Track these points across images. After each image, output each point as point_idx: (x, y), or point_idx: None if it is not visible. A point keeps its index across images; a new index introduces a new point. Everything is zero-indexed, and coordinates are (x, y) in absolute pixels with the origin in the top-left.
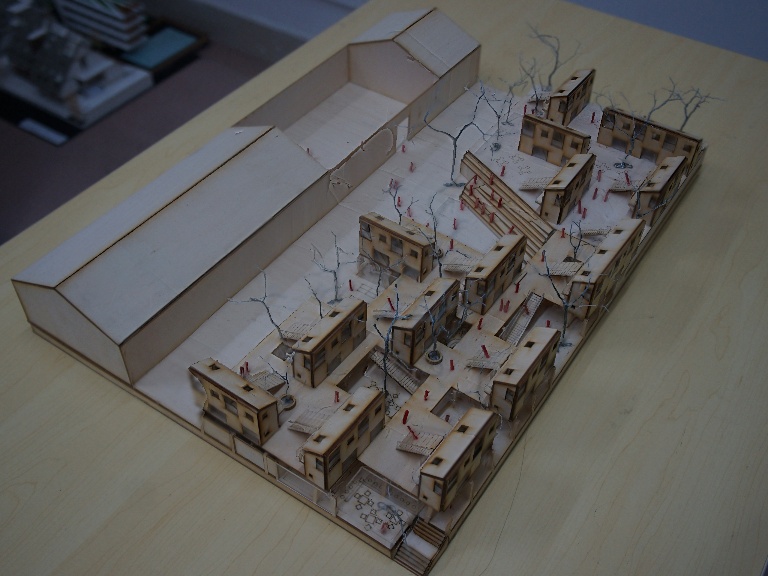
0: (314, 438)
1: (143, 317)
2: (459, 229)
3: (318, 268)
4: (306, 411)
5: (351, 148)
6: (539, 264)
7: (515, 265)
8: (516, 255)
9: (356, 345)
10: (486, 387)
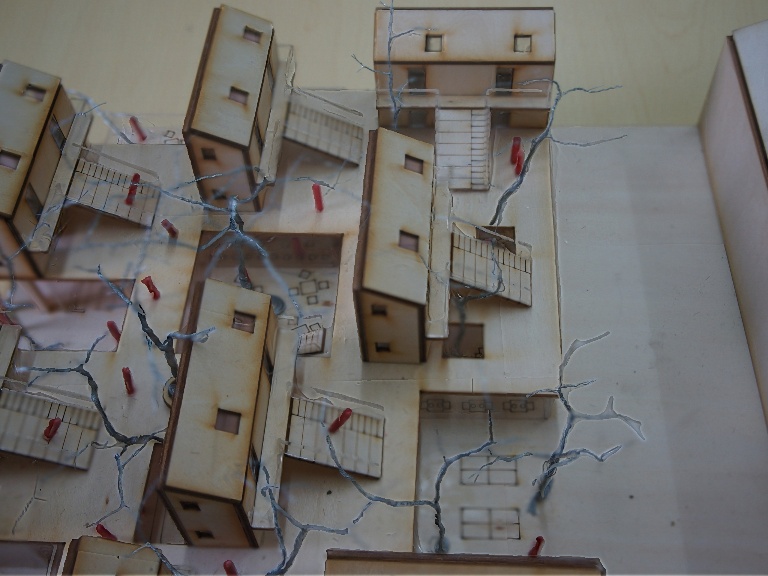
0: (264, 36)
1: (760, 81)
2: None
3: (671, 573)
4: (355, 158)
5: None
6: None
7: None
8: None
9: None
10: (16, 329)
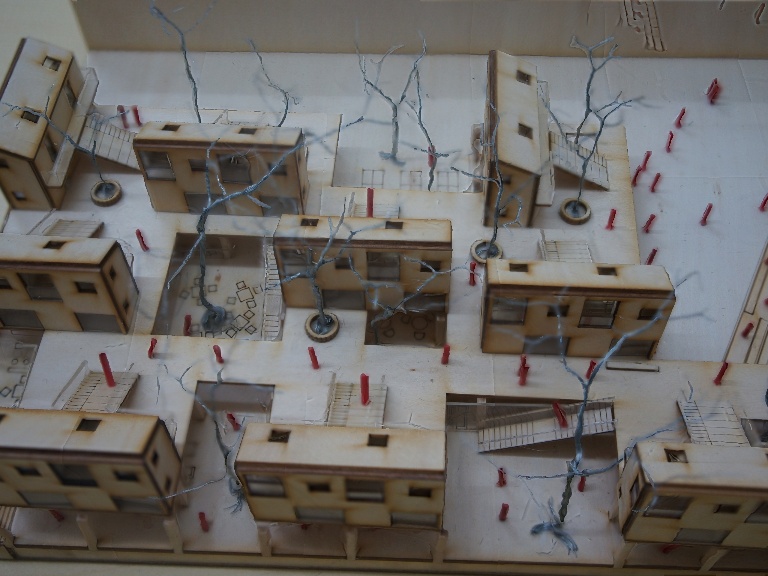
0: None
1: None
2: (708, 229)
3: (443, 106)
4: (98, 221)
5: (746, 7)
6: (702, 380)
7: (621, 329)
8: (622, 309)
9: (274, 213)
10: None
